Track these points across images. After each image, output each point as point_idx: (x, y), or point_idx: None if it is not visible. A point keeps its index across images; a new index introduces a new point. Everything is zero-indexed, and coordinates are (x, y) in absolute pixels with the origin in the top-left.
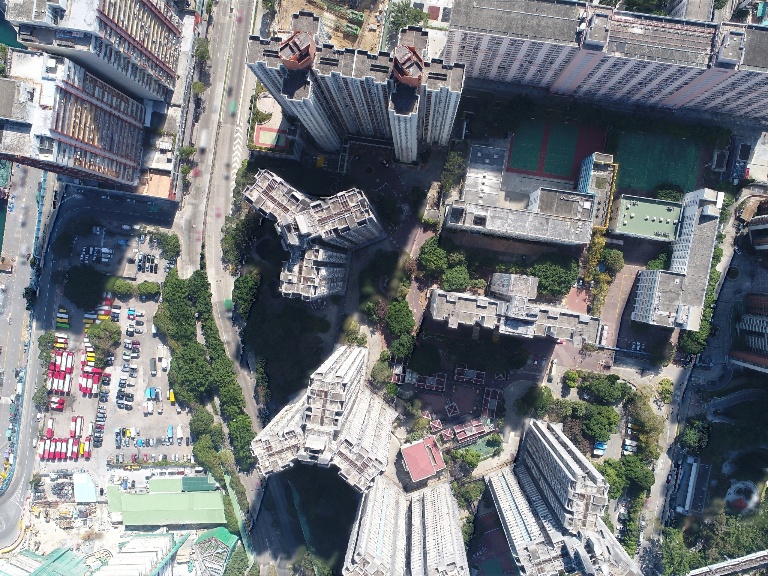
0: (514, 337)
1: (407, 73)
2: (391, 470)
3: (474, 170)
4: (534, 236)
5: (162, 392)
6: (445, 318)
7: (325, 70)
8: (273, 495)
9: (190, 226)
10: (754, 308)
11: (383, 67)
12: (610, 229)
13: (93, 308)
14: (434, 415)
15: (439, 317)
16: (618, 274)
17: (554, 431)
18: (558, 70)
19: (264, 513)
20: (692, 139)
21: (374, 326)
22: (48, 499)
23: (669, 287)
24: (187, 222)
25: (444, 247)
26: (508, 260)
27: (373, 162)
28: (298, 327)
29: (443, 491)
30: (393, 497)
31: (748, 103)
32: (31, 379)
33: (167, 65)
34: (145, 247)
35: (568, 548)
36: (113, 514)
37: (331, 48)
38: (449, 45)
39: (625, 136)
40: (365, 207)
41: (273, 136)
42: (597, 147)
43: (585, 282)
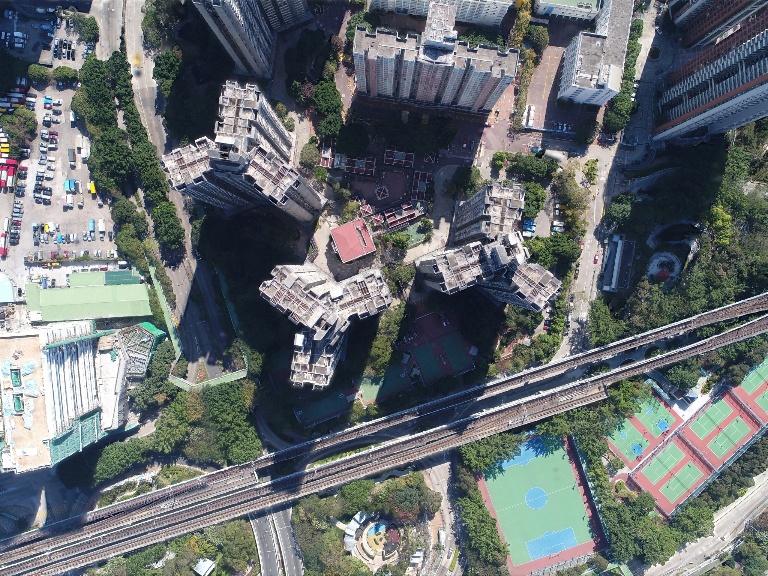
0: None
1: None
2: (322, 260)
3: None
4: (458, 2)
5: (82, 185)
6: (365, 52)
7: None
8: (201, 289)
9: (109, 10)
10: (674, 83)
11: None
12: (535, 7)
13: (5, 92)
14: (364, 201)
15: (359, 52)
16: (544, 56)
17: None
18: None
19: (192, 308)
20: None
21: (302, 112)
22: None
23: (591, 49)
24: (106, 6)
25: (370, 21)
26: None
27: None
28: None
29: None
30: None
31: None
32: None
33: None
34: (61, 32)
35: (485, 247)
36: (32, 313)
37: None
38: None
39: None
40: None
41: None
42: None
43: None
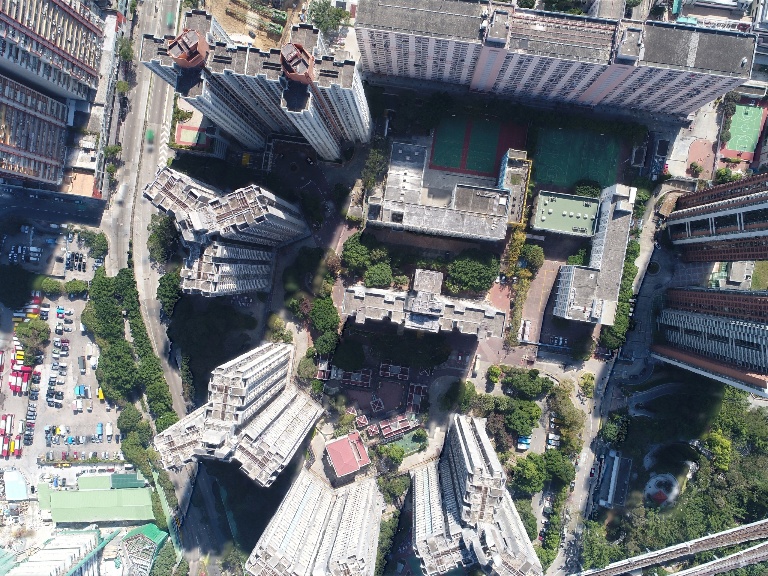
0: (438, 333)
1: (294, 70)
2: (319, 466)
3: (395, 167)
4: (452, 232)
5: (91, 390)
6: (353, 314)
7: (219, 68)
8: (202, 491)
9: (118, 224)
10: (673, 302)
11: (275, 65)
12: (531, 225)
13: (21, 307)
14: (360, 411)
15: (347, 313)
16: (540, 270)
17: (474, 426)
18: (471, 67)
19: (193, 509)
20: (612, 135)
21: (300, 323)
22: None
23: (584, 282)
24: (115, 221)
25: (365, 244)
26: (432, 256)
27: (298, 160)
28: (223, 324)
29: (367, 486)
30: (317, 492)
31: (661, 99)
32: None
33: (87, 64)
34: (73, 246)
35: (464, 540)
36: (43, 511)
37: (224, 46)
38: (360, 43)
39: (546, 133)
40: (264, 204)
41: (194, 134)
42: (518, 144)
43: (508, 278)
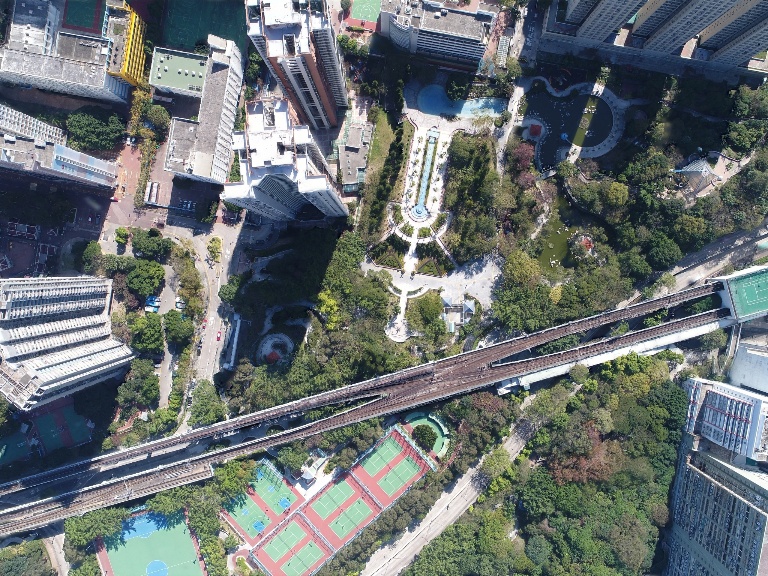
0: None
1: None
2: None
3: (19, 21)
4: (58, 82)
5: None
6: None
7: None
8: None
9: None
10: None
11: None
12: None
13: None
14: None
15: None
16: None
17: None
18: None
19: None
20: (242, 1)
21: None
22: None
23: (184, 134)
24: None
25: None
26: None
27: None
28: None
29: None
30: None
31: None
32: None
33: None
34: None
35: None
36: None
37: None
38: None
39: None
40: None
41: None
42: None
43: (139, 140)
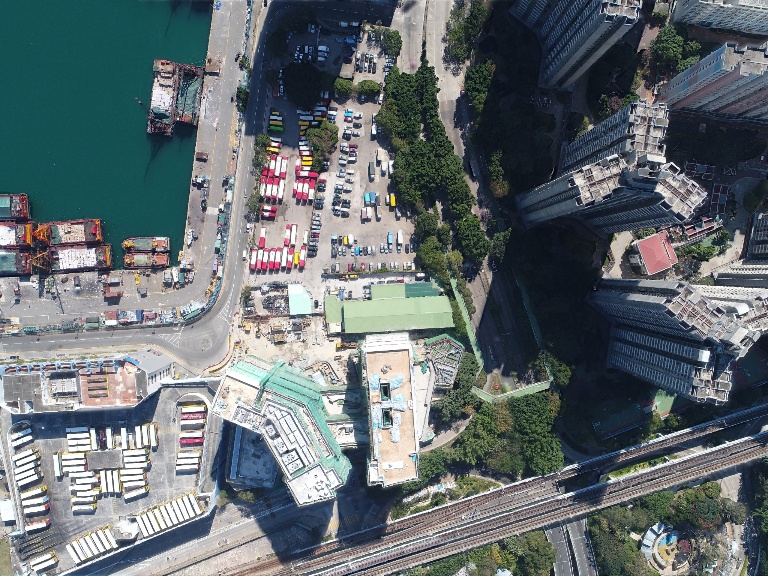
0: None
1: None
2: (616, 272)
3: None
4: None
5: (380, 198)
6: (734, 68)
7: None
8: (496, 301)
9: (410, 24)
10: None
11: None
12: None
13: (314, 106)
14: None
15: (727, 68)
16: None
17: None
18: None
19: (487, 320)
20: None
21: None
22: (258, 314)
23: None
24: (407, 20)
25: (682, 34)
26: None
27: None
28: (530, 121)
29: None
30: None
31: None
32: (240, 187)
33: None
34: (362, 46)
35: None
36: (331, 325)
37: None
38: None
39: None
40: None
41: None
42: None
43: None
